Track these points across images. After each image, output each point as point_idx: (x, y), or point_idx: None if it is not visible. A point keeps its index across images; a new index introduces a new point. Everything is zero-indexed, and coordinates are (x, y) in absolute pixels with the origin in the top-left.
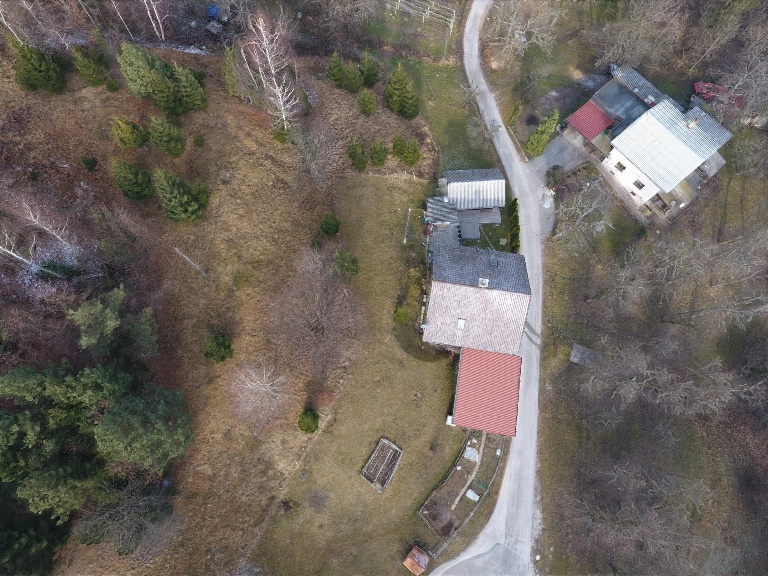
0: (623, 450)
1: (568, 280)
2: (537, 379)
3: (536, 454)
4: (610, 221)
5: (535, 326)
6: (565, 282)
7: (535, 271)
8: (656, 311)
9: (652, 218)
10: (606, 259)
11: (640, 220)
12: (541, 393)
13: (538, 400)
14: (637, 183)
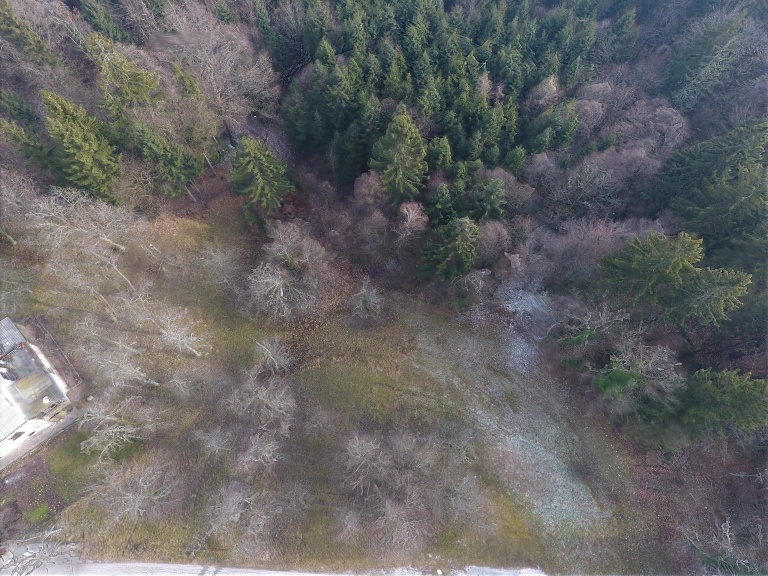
0: (334, 459)
1: (140, 520)
2: (256, 572)
3: (338, 575)
4: (67, 461)
5: (193, 574)
6: (142, 525)
7: (121, 573)
8: (190, 397)
9: (72, 403)
10: (118, 466)
11: (72, 420)
12: (272, 567)
13: (280, 572)
14: (14, 436)
